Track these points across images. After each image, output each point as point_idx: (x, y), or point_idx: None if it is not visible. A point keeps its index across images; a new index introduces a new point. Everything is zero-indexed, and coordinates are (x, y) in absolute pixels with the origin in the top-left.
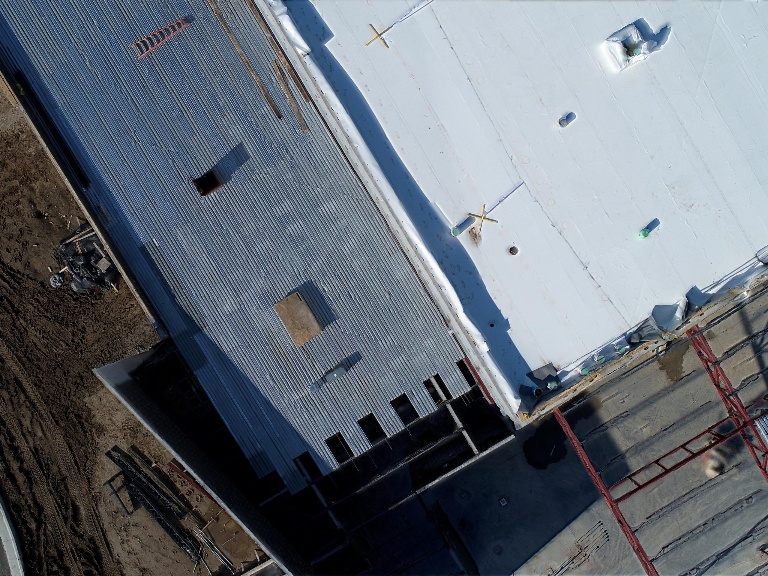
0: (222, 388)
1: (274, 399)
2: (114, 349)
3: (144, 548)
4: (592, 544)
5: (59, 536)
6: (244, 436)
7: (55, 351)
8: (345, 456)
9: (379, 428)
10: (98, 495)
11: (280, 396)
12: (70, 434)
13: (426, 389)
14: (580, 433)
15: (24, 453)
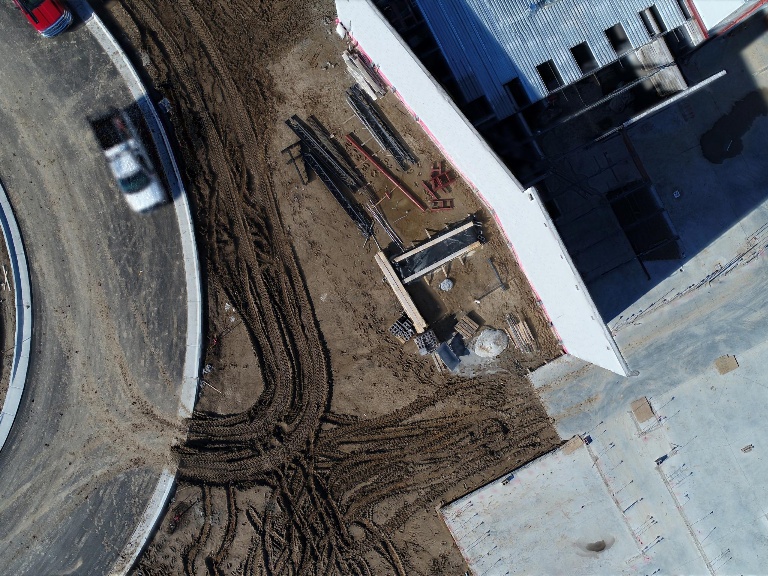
0: (438, 8)
1: (489, 22)
2: (301, 18)
3: (316, 221)
4: (762, 242)
5: (231, 205)
6: (456, 58)
7: (242, 17)
8: (555, 84)
9: (590, 59)
10: (274, 164)
11: (495, 20)
12: (251, 101)
13: (641, 20)
14: (758, 130)
15: (203, 119)
